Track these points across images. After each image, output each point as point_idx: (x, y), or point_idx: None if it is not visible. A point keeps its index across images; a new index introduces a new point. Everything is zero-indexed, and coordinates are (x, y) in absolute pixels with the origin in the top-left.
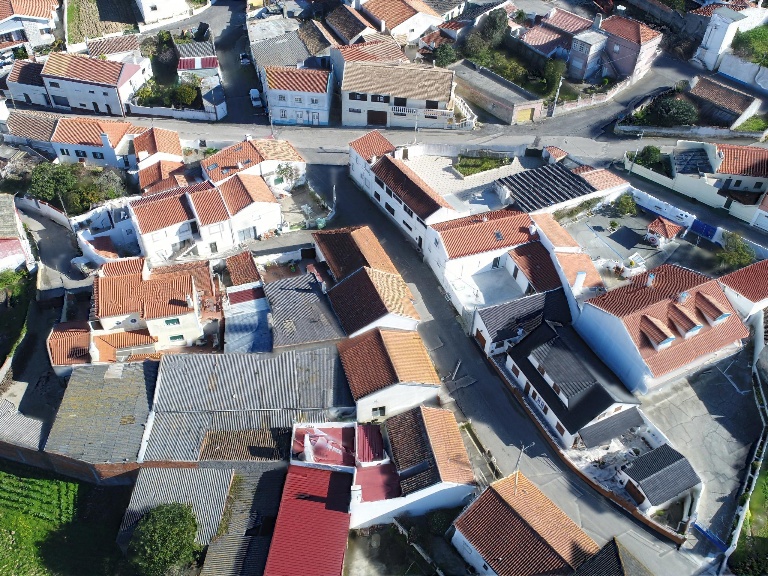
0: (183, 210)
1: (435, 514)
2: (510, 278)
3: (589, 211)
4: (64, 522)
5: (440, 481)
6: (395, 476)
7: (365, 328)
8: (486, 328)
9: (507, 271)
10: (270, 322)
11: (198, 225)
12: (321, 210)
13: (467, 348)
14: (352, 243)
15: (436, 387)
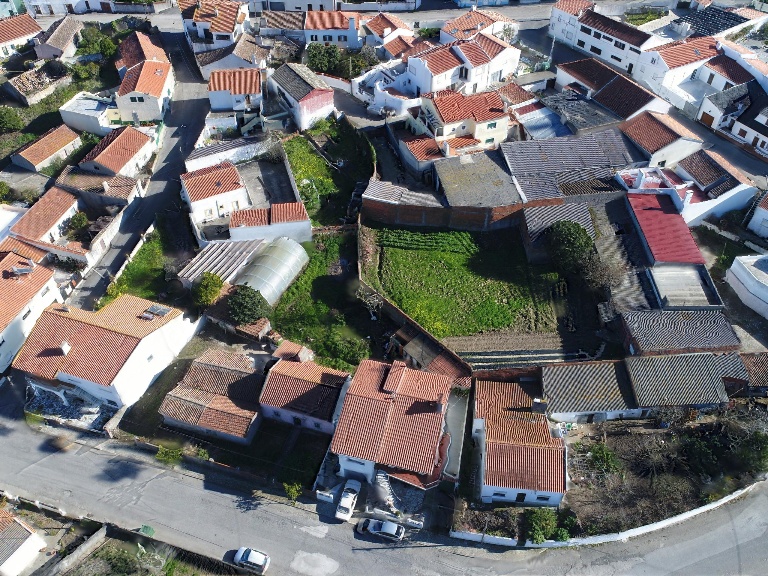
0: (455, 58)
1: (732, 212)
2: (706, 84)
3: (744, 37)
4: (473, 253)
5: (741, 183)
6: (701, 191)
7: (638, 111)
8: (716, 107)
9: (701, 81)
10: (567, 116)
11: (468, 68)
12: (538, 59)
13: (697, 128)
14: (597, 64)
15: (700, 143)
